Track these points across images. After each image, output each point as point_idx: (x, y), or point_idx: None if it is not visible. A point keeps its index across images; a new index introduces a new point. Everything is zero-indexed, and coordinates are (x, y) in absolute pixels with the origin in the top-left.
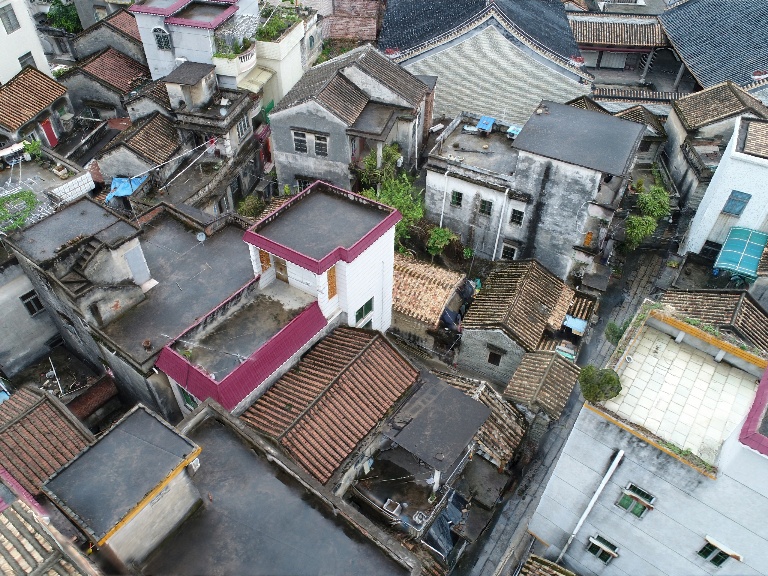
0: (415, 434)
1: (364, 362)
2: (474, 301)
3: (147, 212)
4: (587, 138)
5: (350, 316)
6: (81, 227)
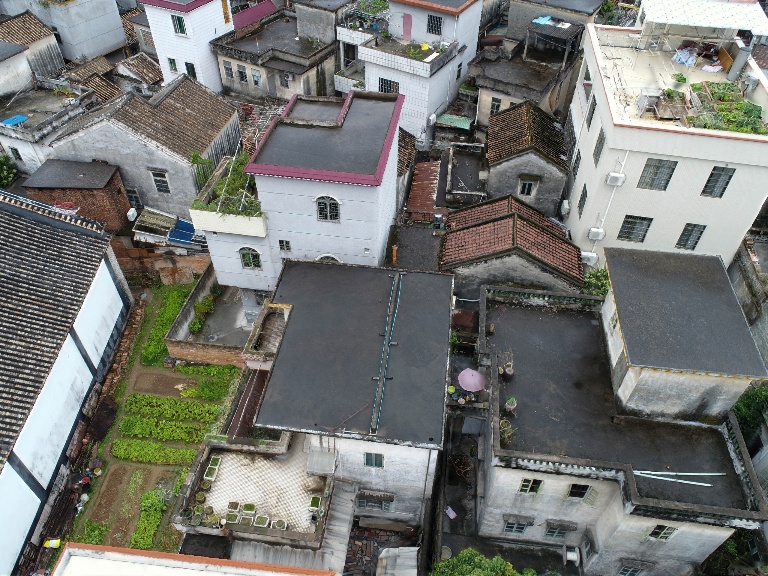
0: None
1: None
2: (105, 101)
3: (315, 53)
4: None
5: None
6: (325, 0)
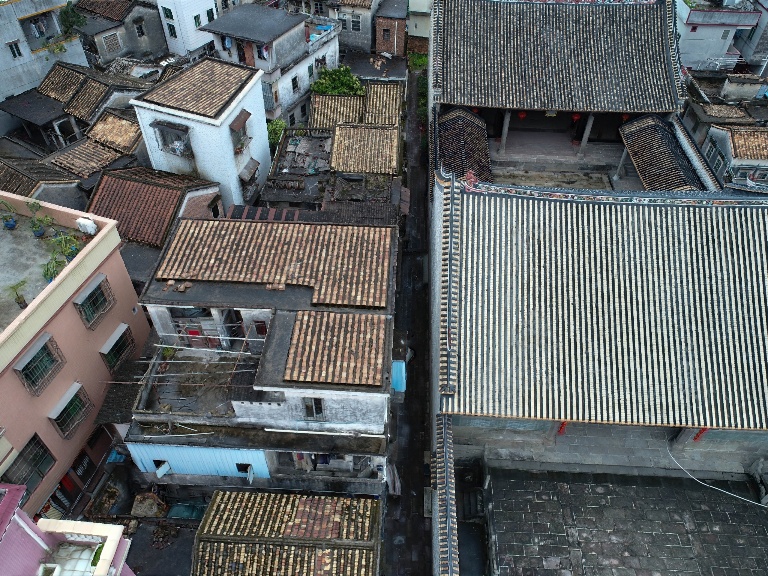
0: (89, 20)
1: (122, 1)
2: None
3: None
4: (250, 22)
5: (159, 5)
6: None
